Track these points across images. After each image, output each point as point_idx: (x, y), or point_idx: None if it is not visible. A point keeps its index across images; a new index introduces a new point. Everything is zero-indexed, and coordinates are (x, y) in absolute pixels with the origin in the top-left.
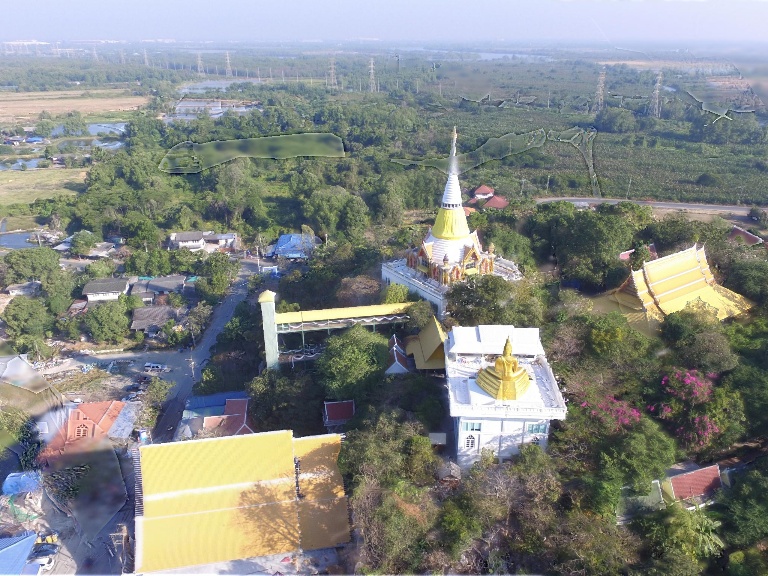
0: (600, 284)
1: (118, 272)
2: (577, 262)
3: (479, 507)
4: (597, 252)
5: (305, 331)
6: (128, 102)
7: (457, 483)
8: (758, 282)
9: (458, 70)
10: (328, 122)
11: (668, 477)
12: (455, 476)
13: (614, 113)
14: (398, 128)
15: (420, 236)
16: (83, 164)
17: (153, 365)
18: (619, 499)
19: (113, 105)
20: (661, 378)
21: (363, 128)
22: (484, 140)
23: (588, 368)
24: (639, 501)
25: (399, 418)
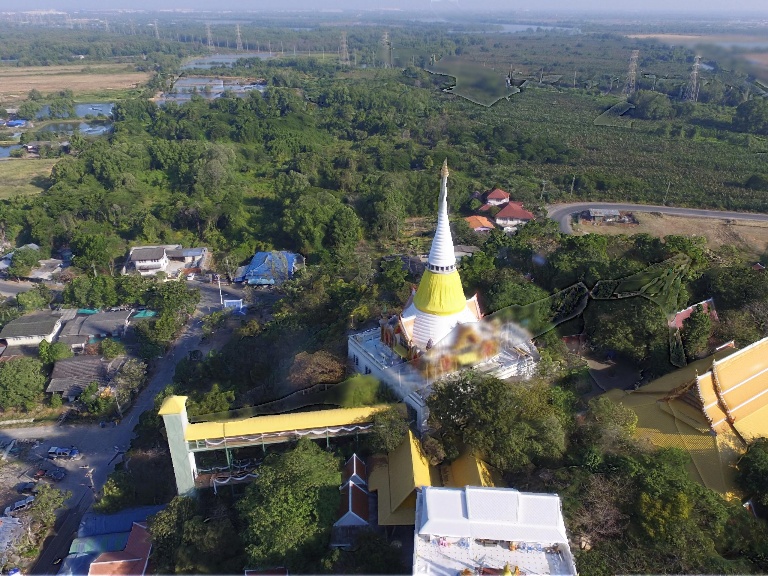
0: (642, 359)
1: (56, 302)
2: (612, 331)
3: None
4: (639, 318)
5: (229, 448)
6: (128, 79)
7: None
8: None
9: (462, 64)
10: (333, 105)
11: None
12: None
13: (647, 97)
14: (409, 112)
15: (407, 284)
16: (59, 154)
17: (59, 451)
18: None
19: (112, 82)
20: None
21: (369, 113)
22: (501, 130)
23: (635, 570)
24: None
25: None
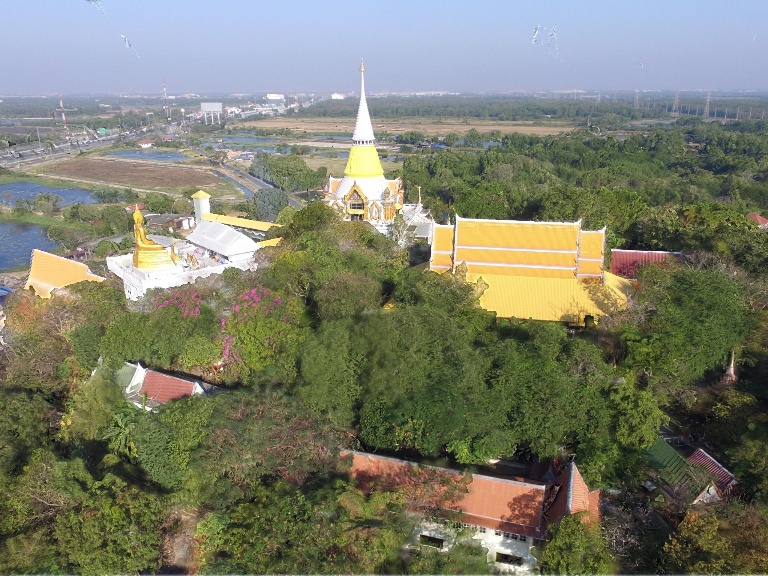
0: None
1: None
2: None
3: None
4: None
5: None
6: None
7: None
8: None
9: None
10: None
11: (148, 369)
12: None
13: None
14: None
15: None
16: None
17: None
18: None
19: (546, 131)
20: None
21: (738, 158)
22: None
23: None
24: (114, 376)
25: None
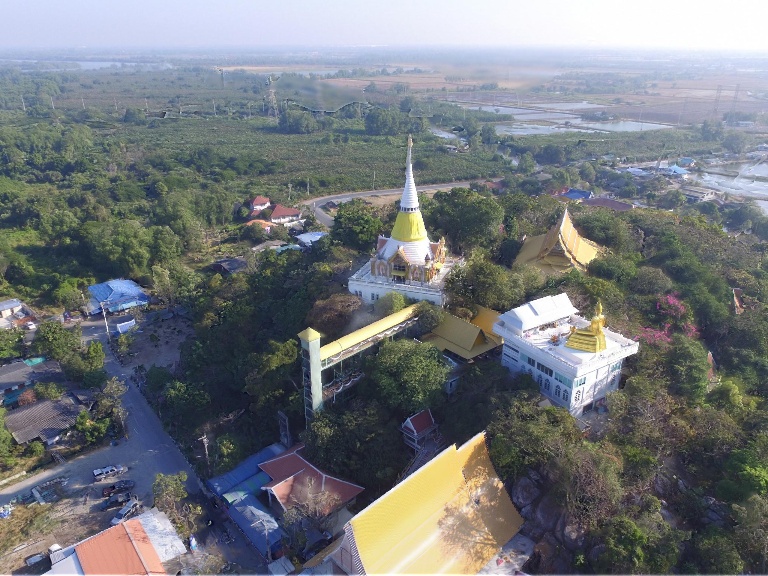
0: None
1: None
2: (475, 242)
3: (632, 438)
4: (486, 231)
5: (343, 360)
6: None
7: (590, 431)
8: (600, 230)
9: (305, 82)
10: None
11: None
12: (589, 426)
13: (297, 116)
14: None
15: (334, 248)
16: None
17: (106, 470)
18: None
19: None
20: (656, 305)
21: (45, 154)
22: (206, 152)
23: (607, 313)
24: None
25: (525, 398)
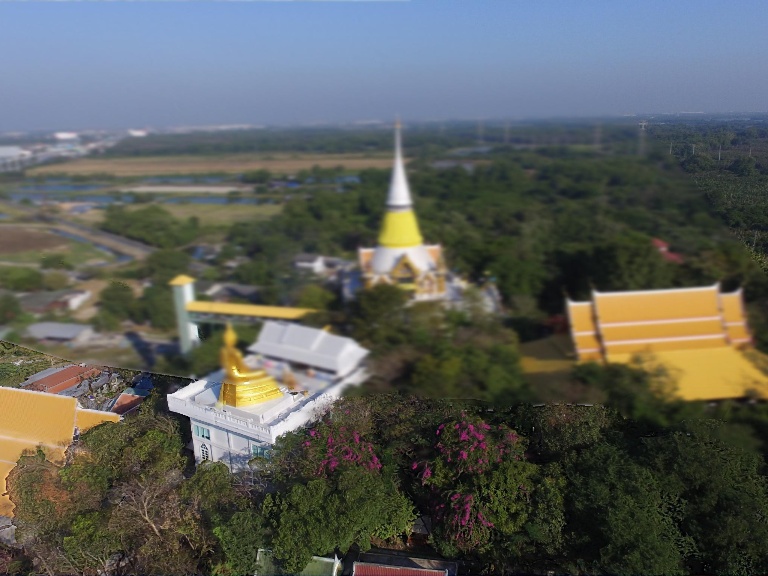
0: None
1: None
2: None
3: None
4: None
5: None
6: None
7: None
8: None
9: None
10: None
11: None
12: None
13: None
14: None
15: None
16: None
17: None
18: (268, 566)
19: None
20: None
21: None
22: None
23: None
24: None
25: None
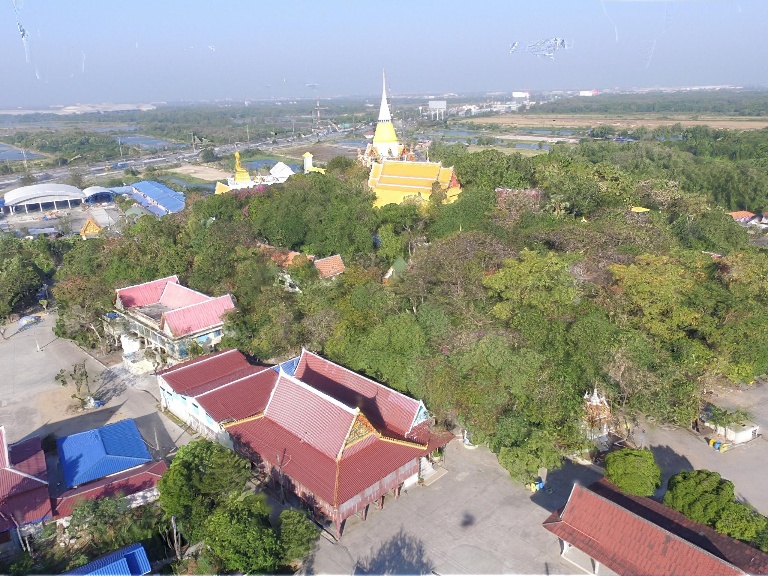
0: None
1: None
2: None
3: None
4: None
5: None
6: None
7: None
8: None
9: None
10: None
11: None
12: None
13: None
14: None
15: None
16: None
17: None
18: None
19: None
20: None
21: None
22: None
23: None
24: None
25: None
